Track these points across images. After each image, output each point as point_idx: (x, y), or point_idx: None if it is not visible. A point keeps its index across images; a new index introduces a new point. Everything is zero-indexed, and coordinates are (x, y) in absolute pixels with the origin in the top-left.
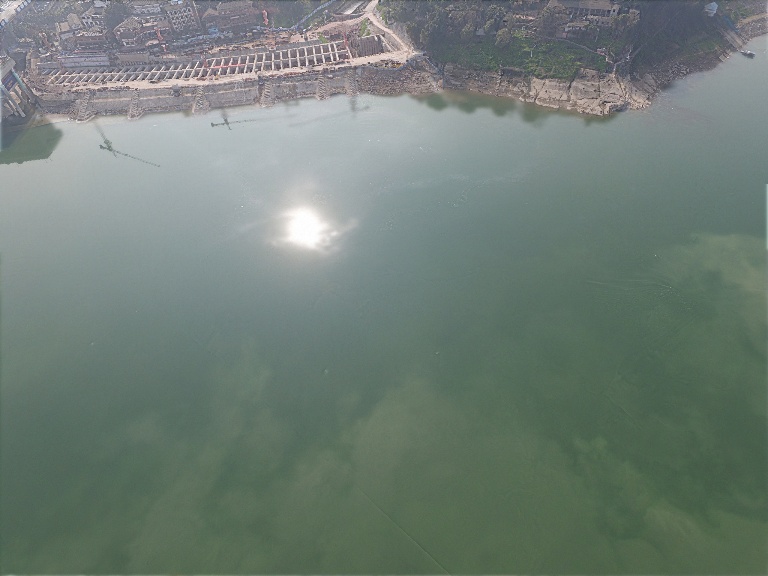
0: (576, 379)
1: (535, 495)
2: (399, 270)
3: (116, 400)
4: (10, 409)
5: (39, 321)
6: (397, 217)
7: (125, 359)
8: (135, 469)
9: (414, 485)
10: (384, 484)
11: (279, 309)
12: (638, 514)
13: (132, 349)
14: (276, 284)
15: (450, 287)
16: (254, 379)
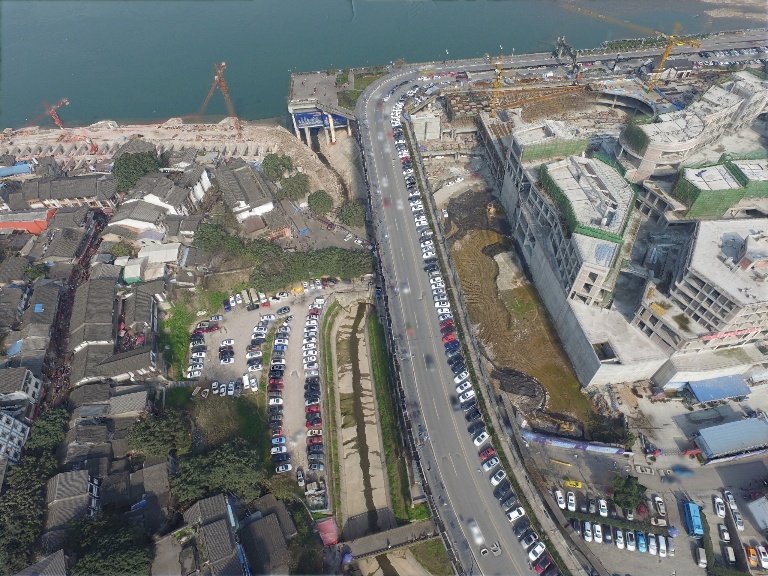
0: (5, 11)
1: None
2: (35, 27)
3: (180, 3)
4: (223, 1)
5: None
6: (12, 43)
7: (175, 7)
8: None
9: None
10: None
11: (101, 14)
12: None
13: (171, 8)
14: None
15: (19, 22)
16: None
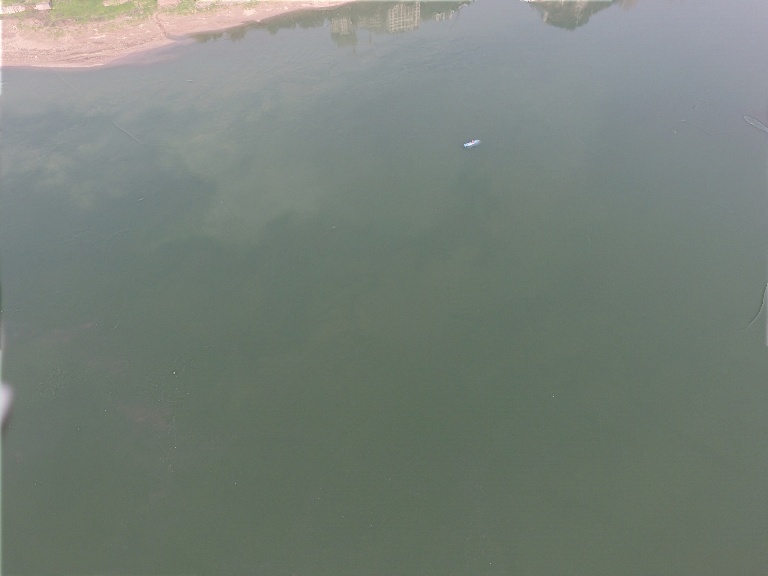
0: None
1: (52, 142)
2: (28, 262)
3: (300, 190)
4: (378, 189)
5: (394, 248)
6: None
7: (297, 209)
8: (279, 161)
9: (115, 150)
10: (131, 150)
11: (159, 231)
12: (8, 137)
13: (291, 213)
14: (155, 254)
15: None
16: (194, 191)
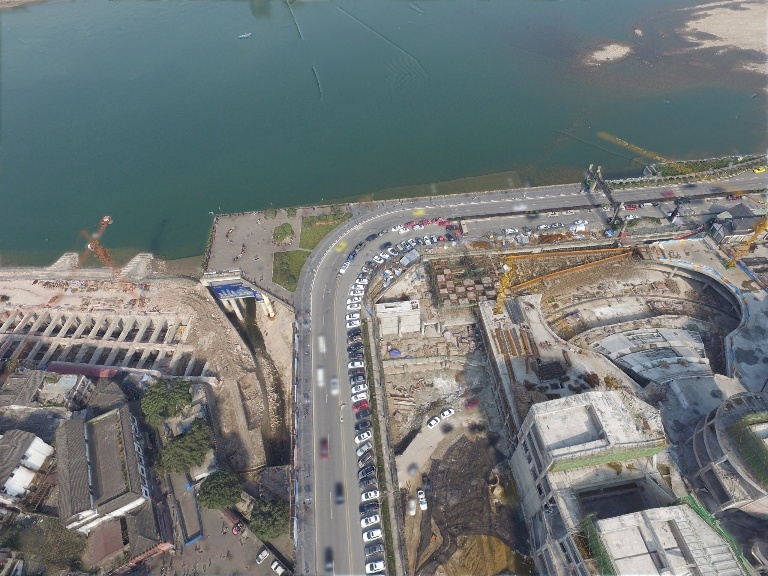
0: None
1: None
2: None
3: None
4: (171, 61)
5: (163, 86)
6: None
7: (111, 70)
8: None
9: None
10: None
11: (19, 80)
12: None
13: (106, 71)
14: (12, 90)
15: None
16: None
